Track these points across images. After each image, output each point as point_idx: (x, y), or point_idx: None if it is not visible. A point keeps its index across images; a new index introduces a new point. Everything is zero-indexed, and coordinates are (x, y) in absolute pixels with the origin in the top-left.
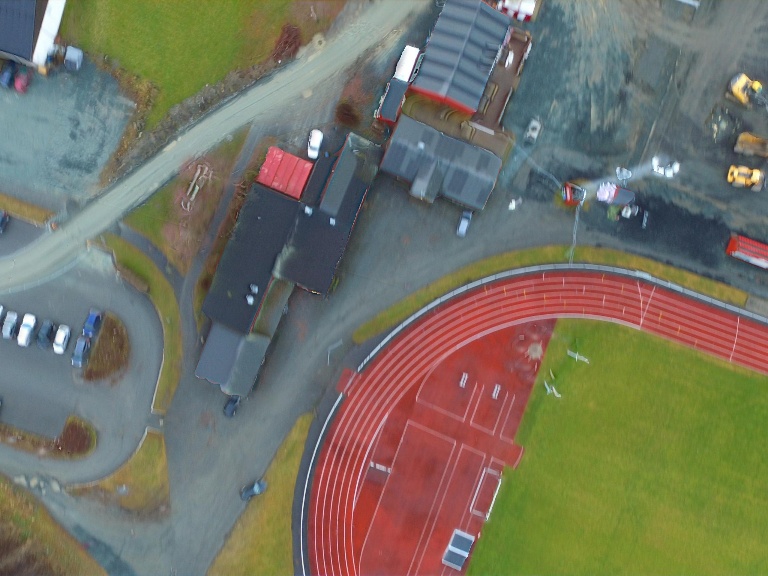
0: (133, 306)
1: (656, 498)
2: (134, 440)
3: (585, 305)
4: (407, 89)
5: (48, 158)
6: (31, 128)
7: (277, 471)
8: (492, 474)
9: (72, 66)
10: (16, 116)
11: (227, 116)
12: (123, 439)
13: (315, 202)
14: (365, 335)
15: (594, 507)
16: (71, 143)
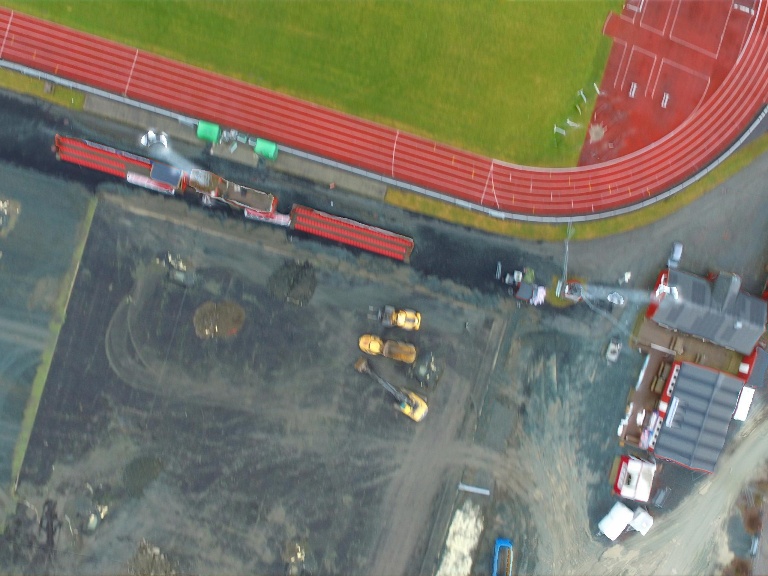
0: None
1: None
2: None
3: (550, 181)
4: (749, 379)
5: None
6: None
7: None
8: (634, 6)
9: None
10: None
11: None
12: None
13: None
14: (763, 141)
15: None
16: None
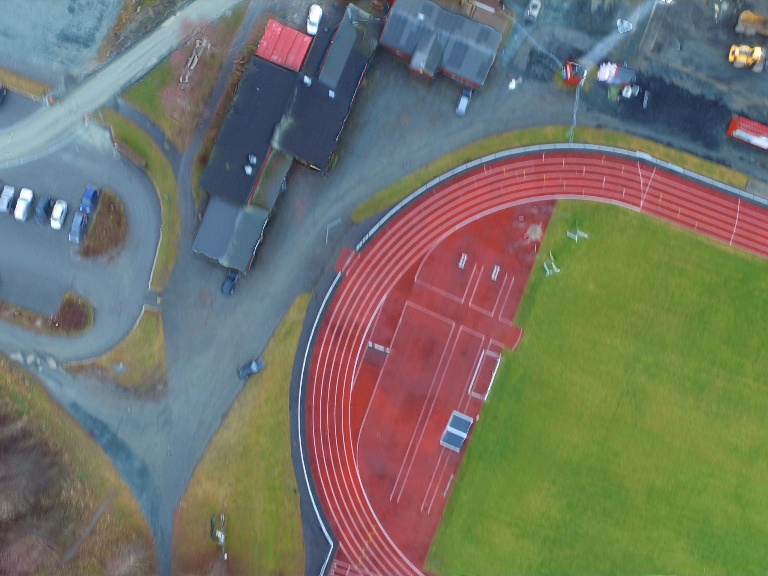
0: (131, 183)
1: (655, 381)
2: (131, 317)
3: (585, 186)
4: None
5: (46, 32)
6: (29, 1)
7: (275, 350)
8: (491, 356)
9: None
10: None
11: None
12: (120, 316)
13: (314, 74)
14: (364, 214)
15: (593, 390)
16: (69, 17)
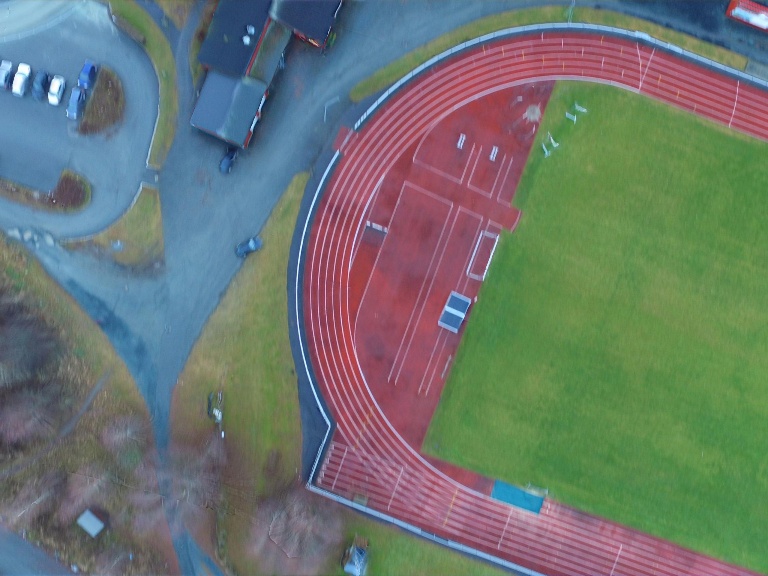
0: (129, 60)
1: (654, 264)
2: (129, 195)
3: (584, 67)
4: None
5: None
6: None
7: (273, 229)
8: (489, 237)
9: None
10: None
11: None
12: (118, 194)
13: None
14: (362, 93)
15: (592, 272)
16: None
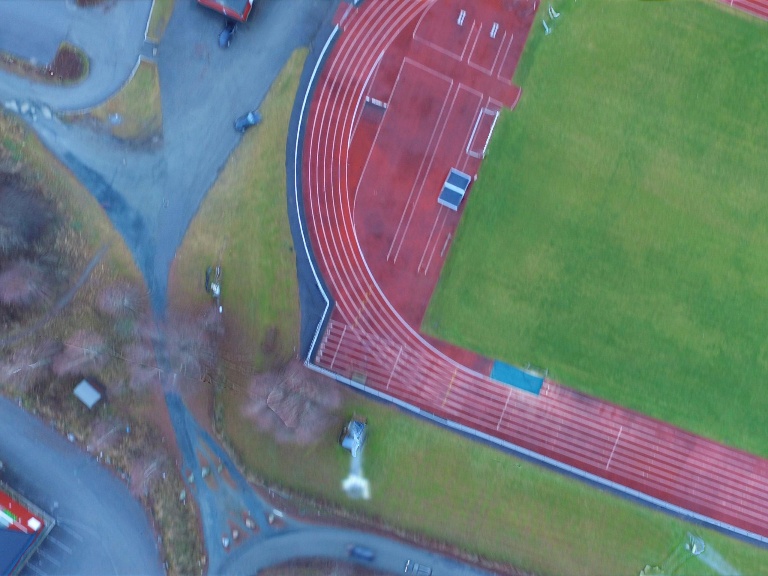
0: None
1: (655, 143)
2: (127, 68)
3: None
4: None
5: None
6: None
7: (271, 104)
8: (489, 114)
9: None
10: None
11: None
12: (116, 67)
13: None
14: None
15: (592, 150)
16: None
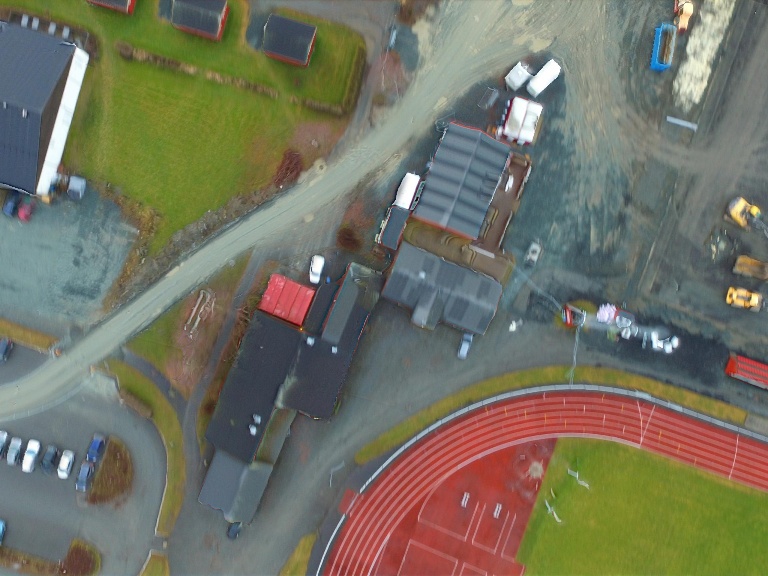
0: (136, 430)
1: None
2: (138, 563)
3: (585, 424)
4: (408, 218)
5: (52, 285)
6: (35, 256)
7: None
8: None
9: (75, 195)
10: (20, 244)
11: (229, 241)
12: (127, 562)
13: (317, 331)
14: (367, 456)
15: None
16: (74, 270)
